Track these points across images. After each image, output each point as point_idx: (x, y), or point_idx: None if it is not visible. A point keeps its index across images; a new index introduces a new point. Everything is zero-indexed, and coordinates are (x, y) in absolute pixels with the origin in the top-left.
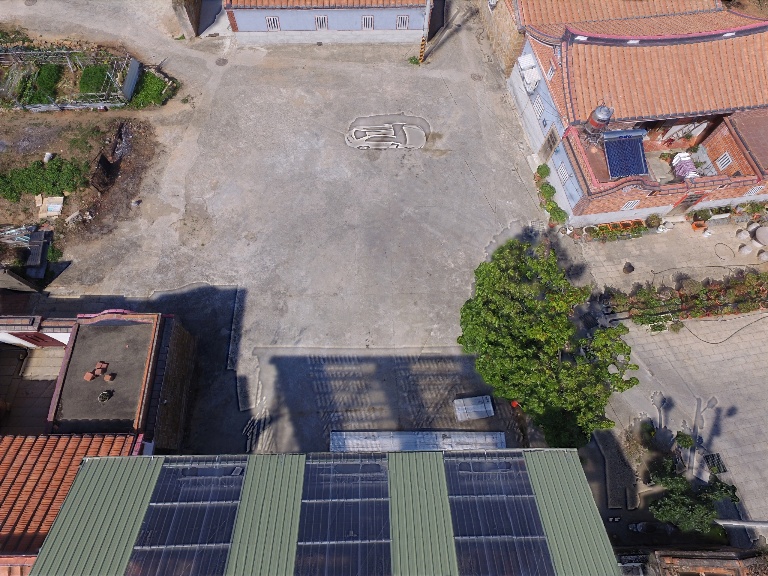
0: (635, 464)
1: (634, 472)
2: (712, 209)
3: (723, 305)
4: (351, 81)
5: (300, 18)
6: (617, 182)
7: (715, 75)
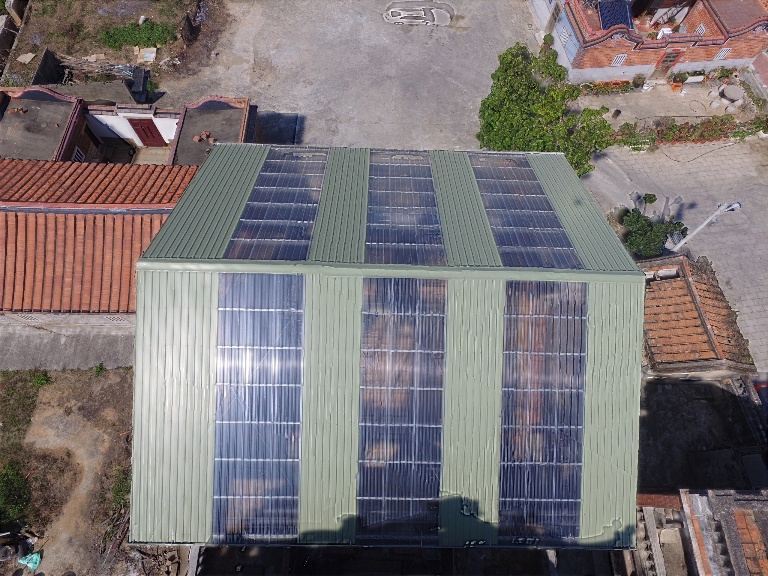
0: None
1: None
2: (688, 72)
3: None
4: None
5: None
6: (607, 30)
7: None
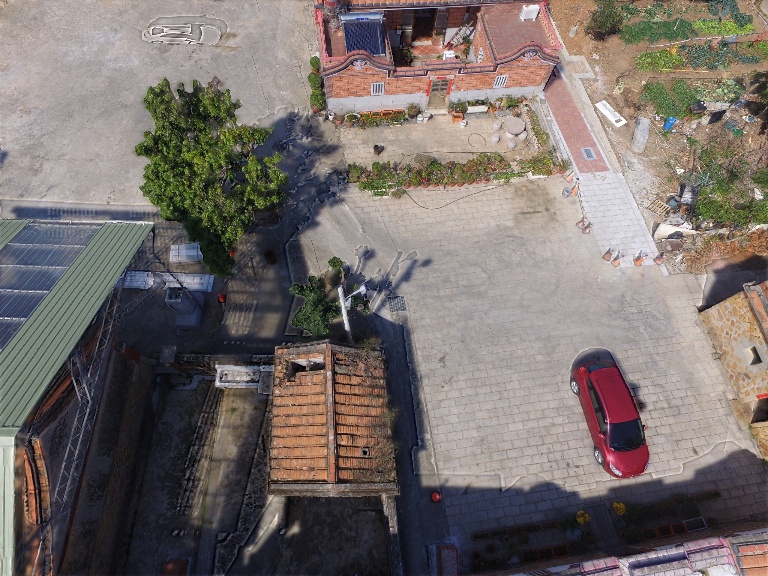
0: None
1: None
2: (469, 102)
3: None
4: None
5: None
6: (345, 57)
7: None
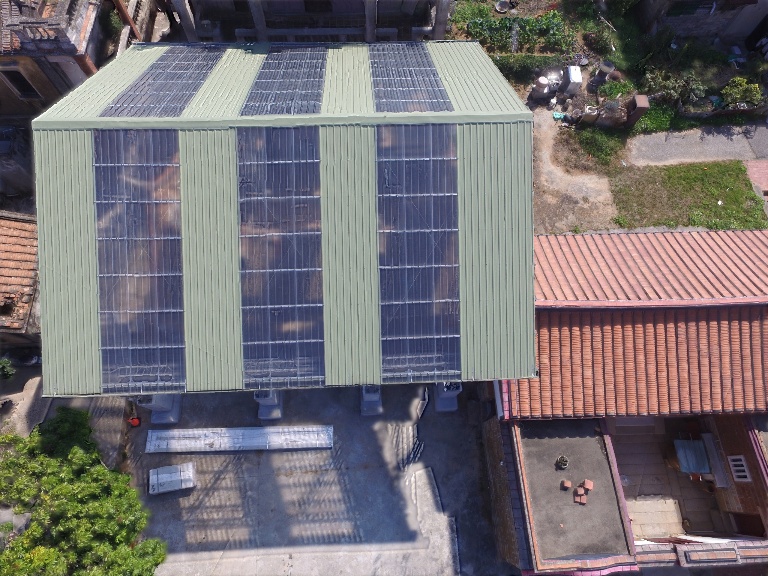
0: (11, 420)
1: (17, 412)
2: None
3: None
4: None
5: None
6: None
7: None
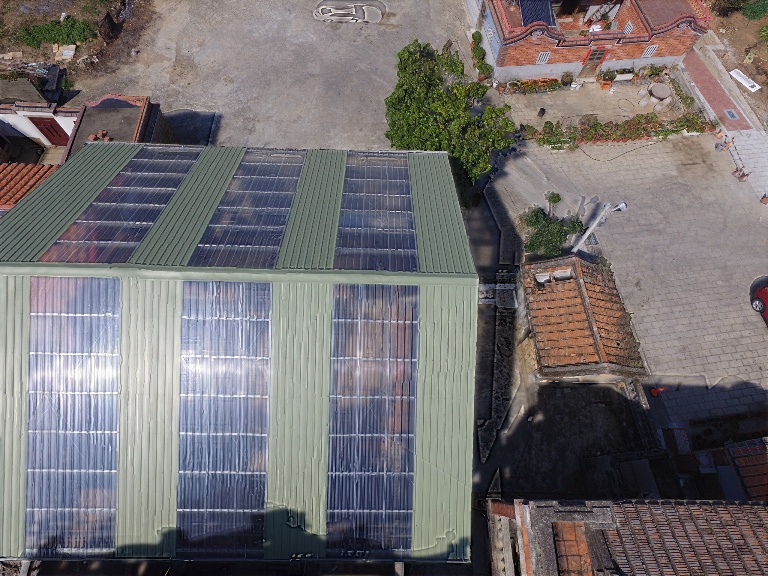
0: (524, 235)
1: (523, 241)
2: (617, 70)
3: None
4: None
5: None
6: (526, 27)
7: None
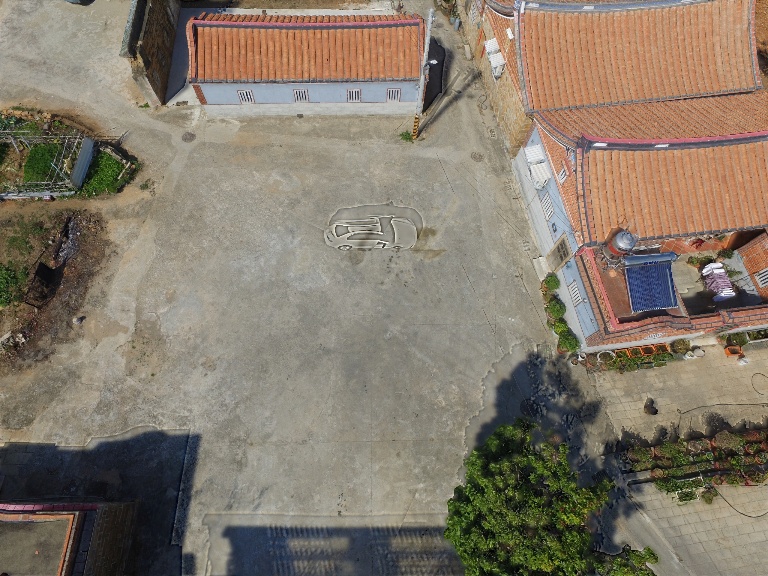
0: None
1: None
2: (749, 333)
3: (764, 464)
4: (334, 162)
5: (277, 91)
6: (640, 322)
7: (758, 183)
